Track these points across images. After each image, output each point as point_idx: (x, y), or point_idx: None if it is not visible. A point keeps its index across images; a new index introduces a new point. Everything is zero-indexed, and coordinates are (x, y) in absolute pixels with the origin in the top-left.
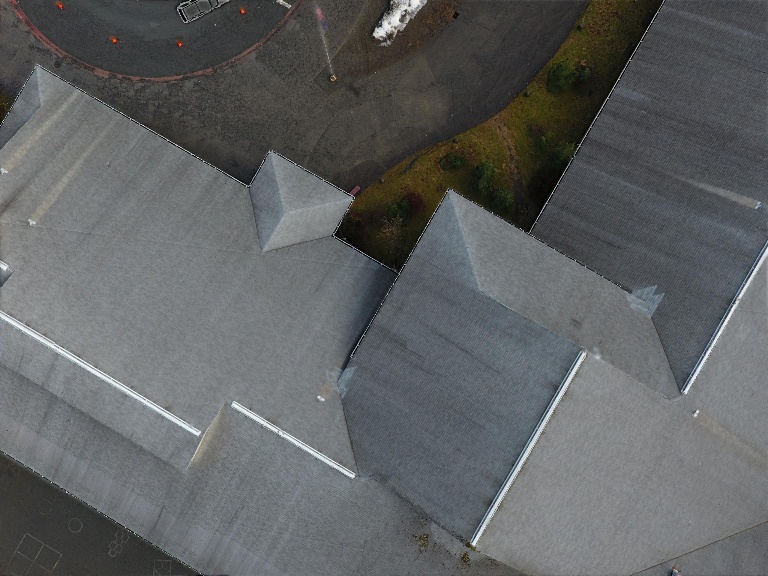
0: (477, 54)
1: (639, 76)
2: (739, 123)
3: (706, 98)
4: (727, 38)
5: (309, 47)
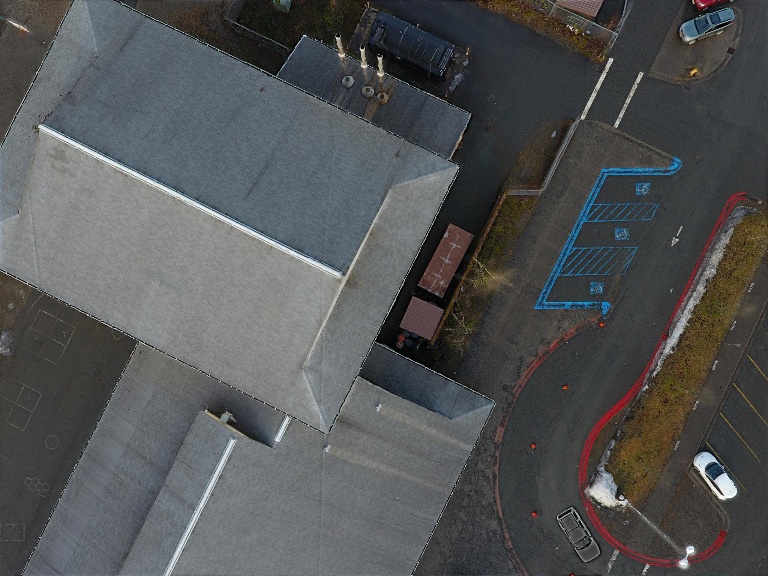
0: None
1: None
2: None
3: None
4: None
5: None
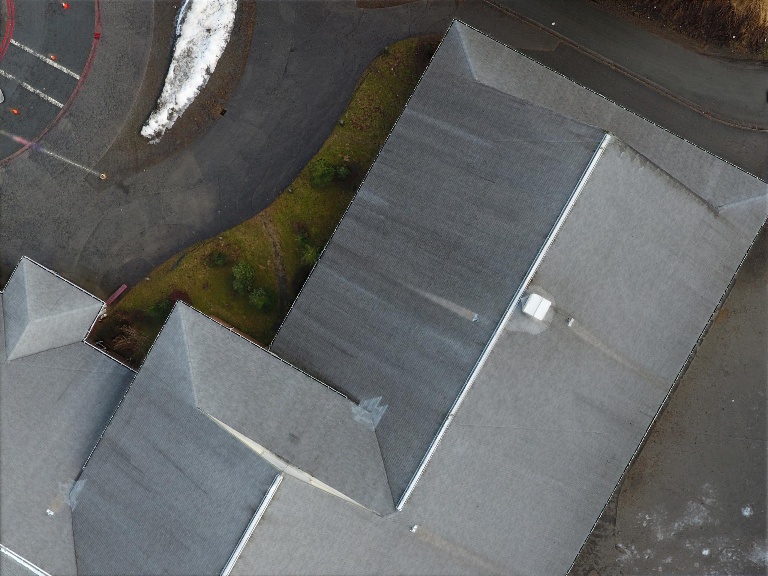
0: (244, 151)
1: (380, 180)
2: (464, 232)
3: (437, 205)
4: (459, 144)
5: (80, 146)
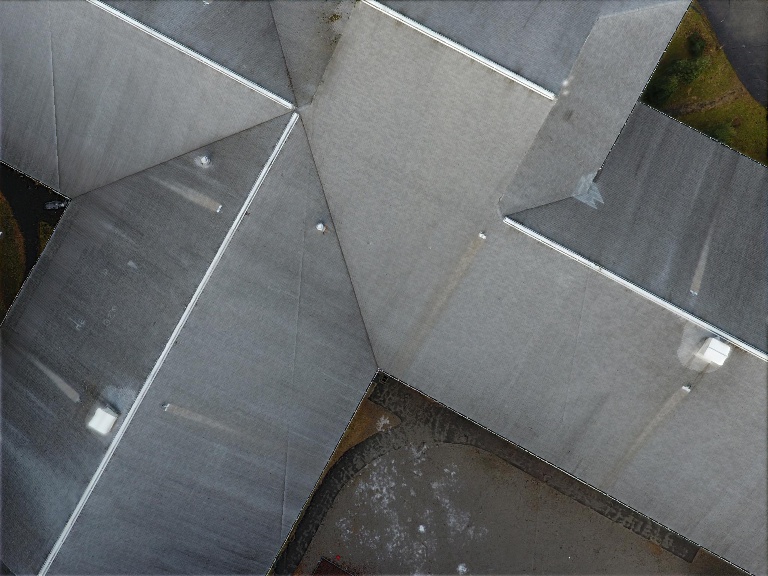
0: None
1: None
2: None
3: None
4: None
5: None
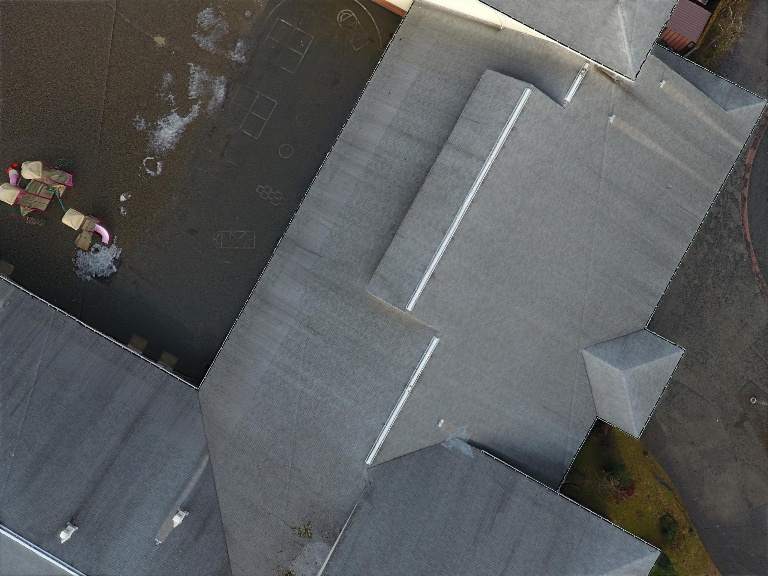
0: None
1: None
2: None
3: None
4: None
5: None
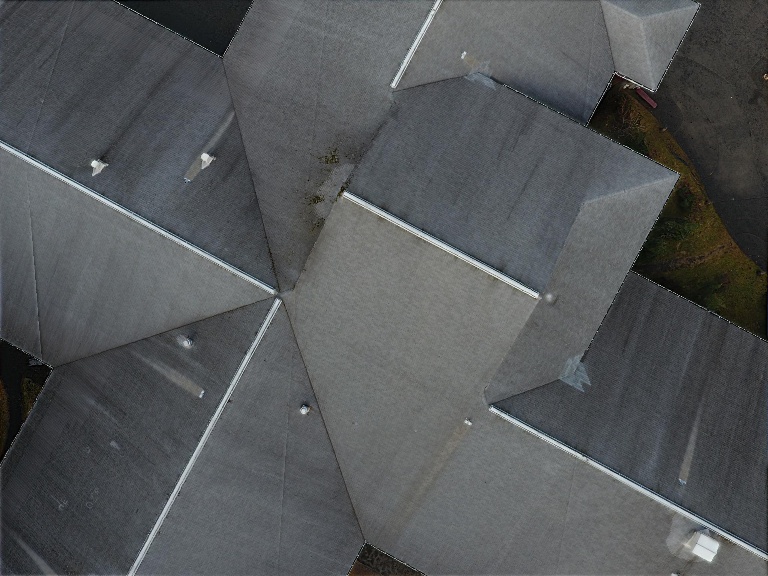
0: None
1: None
2: (762, 466)
3: None
4: None
5: None
